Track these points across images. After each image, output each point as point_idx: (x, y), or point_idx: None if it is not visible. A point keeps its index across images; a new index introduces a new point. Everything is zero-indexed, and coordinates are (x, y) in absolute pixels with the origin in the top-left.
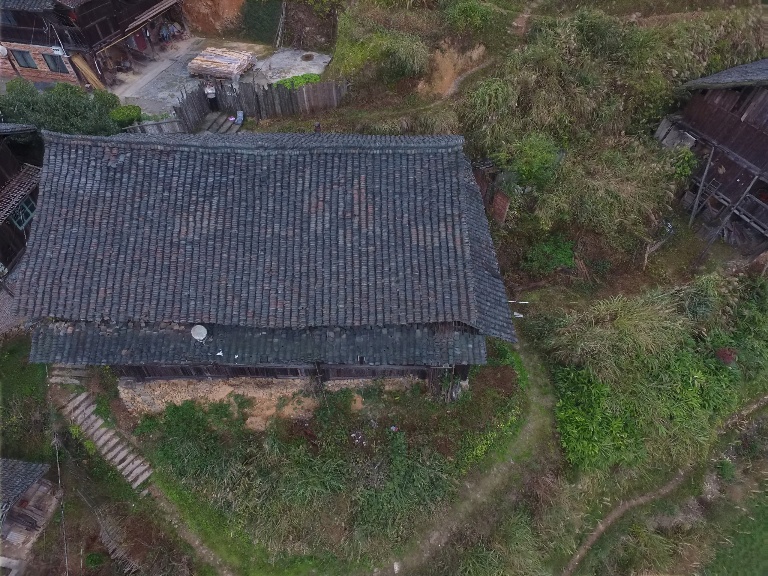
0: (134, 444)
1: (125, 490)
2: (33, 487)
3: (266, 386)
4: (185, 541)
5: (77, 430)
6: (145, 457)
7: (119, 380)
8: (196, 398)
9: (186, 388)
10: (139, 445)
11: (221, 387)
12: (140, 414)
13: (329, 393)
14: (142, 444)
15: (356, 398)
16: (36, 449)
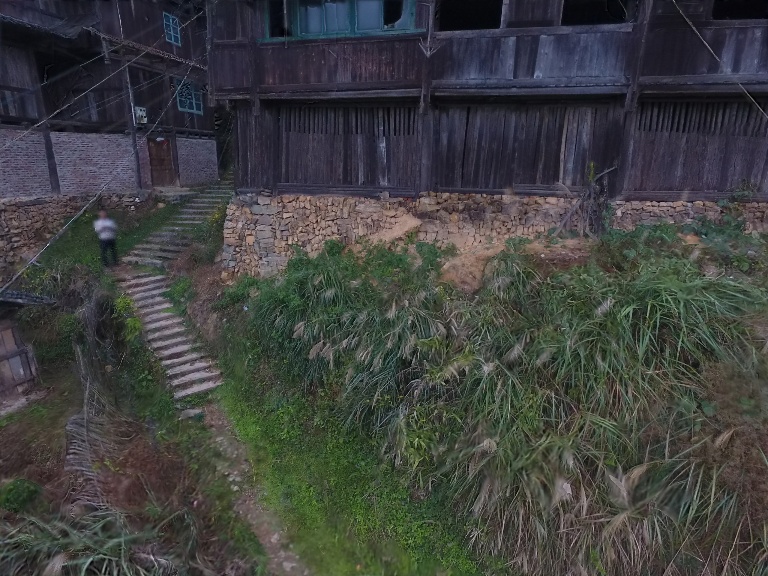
0: (207, 336)
1: (157, 402)
2: (5, 345)
3: (485, 214)
4: (246, 524)
5: (127, 302)
6: (217, 361)
7: (234, 194)
8: (348, 240)
9: (340, 204)
10: (217, 331)
11: (399, 217)
12: (238, 282)
13: (618, 229)
14: (224, 324)
15: (683, 238)
16: (46, 339)
